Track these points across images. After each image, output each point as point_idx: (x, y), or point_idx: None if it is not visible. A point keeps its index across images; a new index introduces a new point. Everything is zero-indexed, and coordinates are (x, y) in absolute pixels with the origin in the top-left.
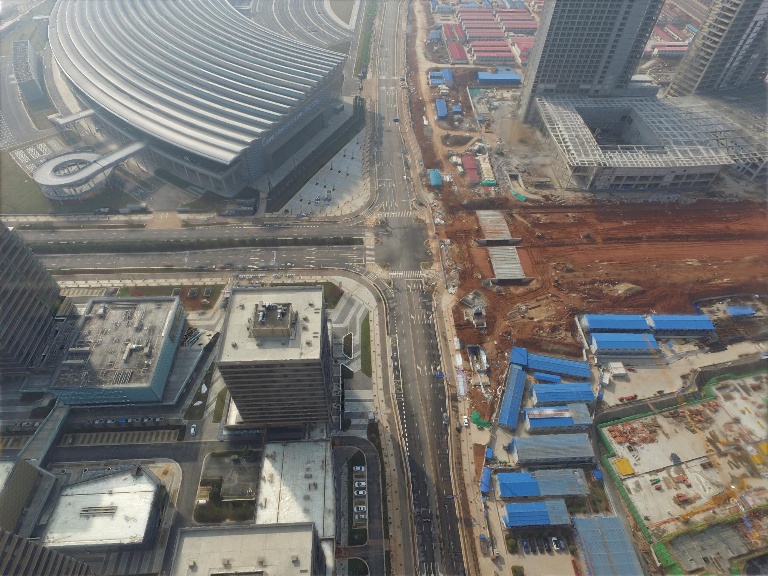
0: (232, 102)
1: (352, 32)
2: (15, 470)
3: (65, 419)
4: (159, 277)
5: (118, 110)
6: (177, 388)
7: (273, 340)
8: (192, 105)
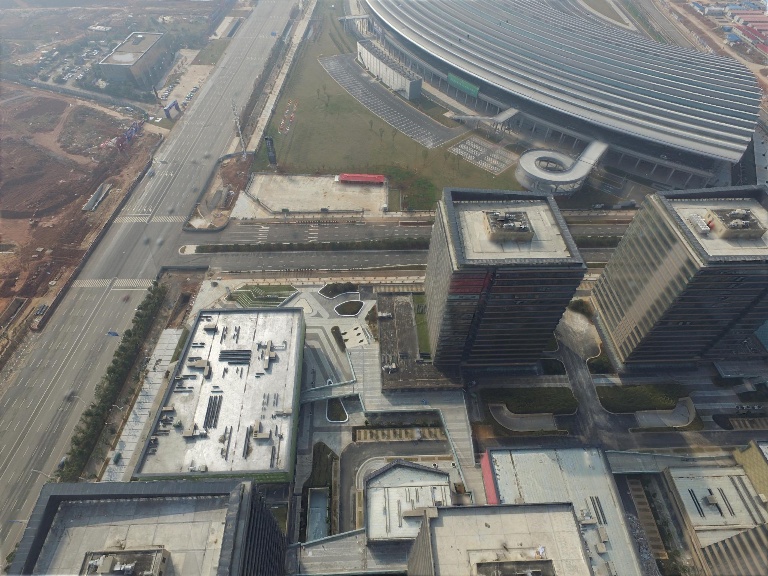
0: (696, 102)
1: (640, 33)
2: None
3: None
4: None
5: (572, 109)
6: None
7: None
8: (652, 105)
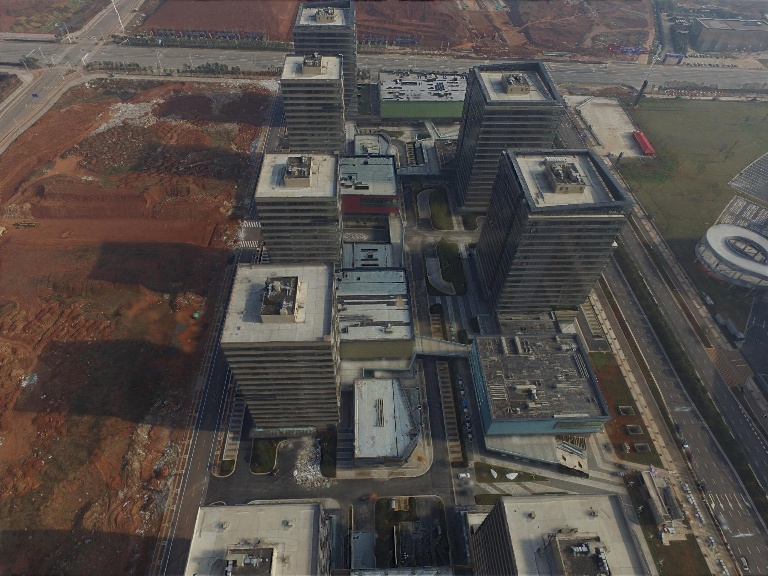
0: None
1: None
2: (405, 341)
3: (458, 357)
4: (641, 385)
5: None
6: (505, 446)
7: (552, 573)
8: None
